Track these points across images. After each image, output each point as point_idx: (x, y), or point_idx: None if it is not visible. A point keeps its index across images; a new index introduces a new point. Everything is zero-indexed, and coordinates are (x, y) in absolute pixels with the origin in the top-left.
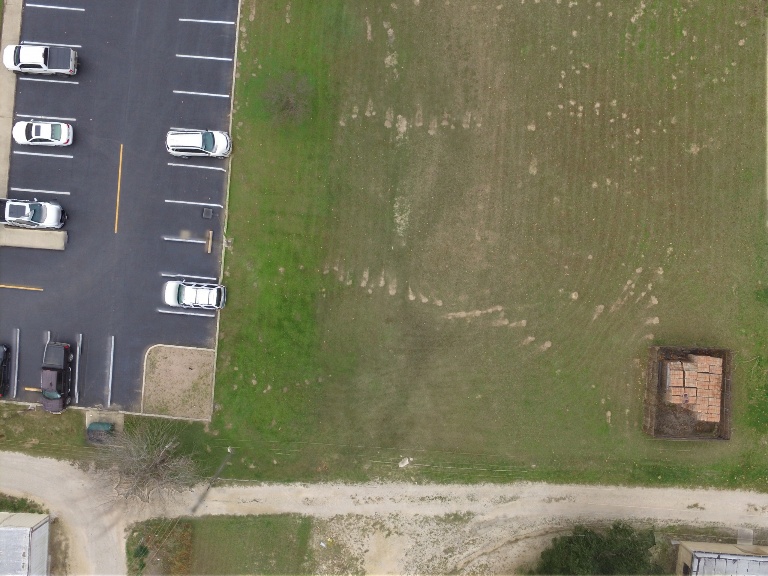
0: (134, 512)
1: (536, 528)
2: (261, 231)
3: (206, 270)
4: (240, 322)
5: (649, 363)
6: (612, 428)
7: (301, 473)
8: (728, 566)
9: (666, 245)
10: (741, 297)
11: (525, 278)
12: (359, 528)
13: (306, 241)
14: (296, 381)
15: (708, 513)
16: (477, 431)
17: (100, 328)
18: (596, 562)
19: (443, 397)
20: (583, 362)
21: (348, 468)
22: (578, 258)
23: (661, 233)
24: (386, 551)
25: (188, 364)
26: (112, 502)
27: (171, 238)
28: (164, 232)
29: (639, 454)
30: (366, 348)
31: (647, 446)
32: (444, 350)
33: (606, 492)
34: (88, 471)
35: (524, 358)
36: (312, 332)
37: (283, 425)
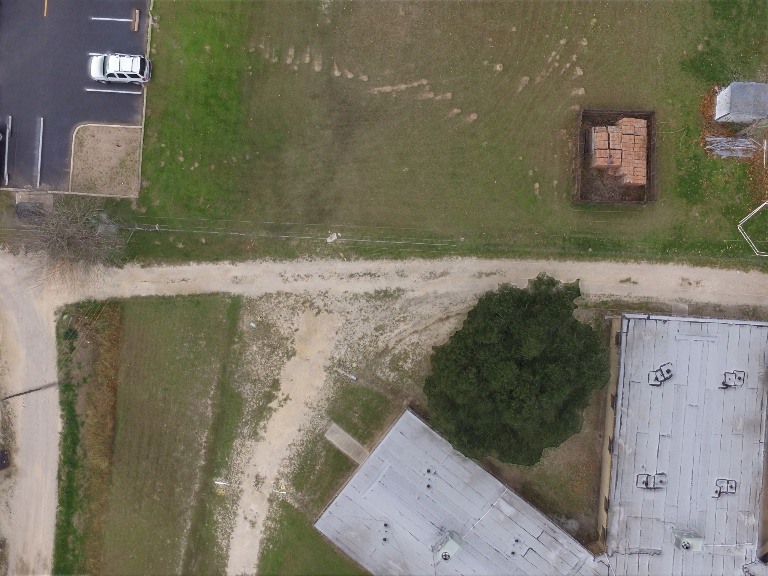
0: (64, 295)
1: (467, 304)
2: (187, 10)
3: (133, 48)
4: (167, 99)
5: (576, 134)
6: (540, 200)
7: (230, 251)
8: (658, 327)
9: (590, 16)
10: (667, 67)
11: (450, 52)
12: (289, 306)
13: (232, 20)
14: (223, 158)
15: (641, 287)
16: (405, 205)
17: (29, 110)
18: (519, 310)
19: (370, 171)
20: (510, 134)
21: (277, 245)
22: (502, 30)
23: (584, 5)
24: (316, 330)
25: (115, 141)
26: (42, 285)
27: (98, 17)
28: (91, 12)
29: (569, 226)
30: (293, 124)
31: (576, 218)
32: (370, 125)
33: (537, 266)
34: (18, 255)
35: (450, 130)
36: (239, 110)
37: (211, 203)
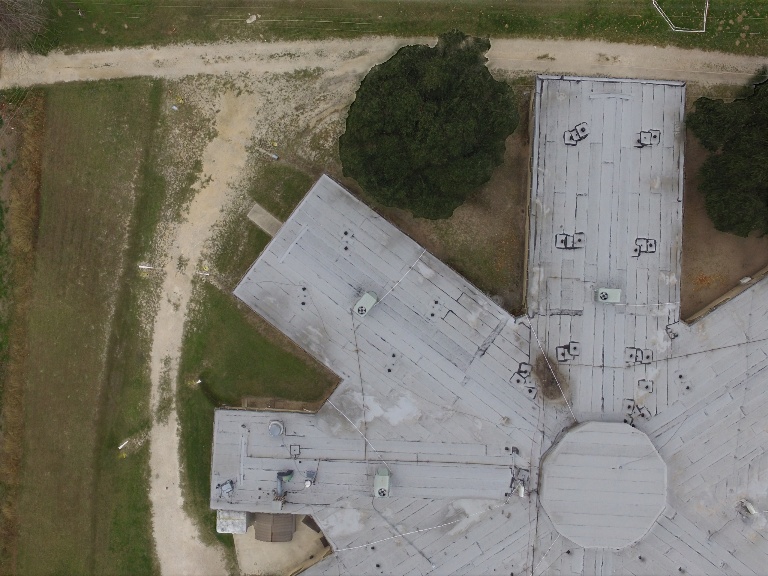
0: None
1: None
2: None
3: None
4: None
5: None
6: None
7: (151, 36)
8: (572, 87)
9: None
10: None
11: None
12: (210, 88)
13: None
14: None
15: (559, 63)
16: None
17: None
18: None
19: None
20: None
21: (197, 28)
22: None
23: None
24: (238, 110)
25: None
26: None
27: None
28: None
29: (485, 3)
30: None
31: None
32: None
33: None
34: None
35: None
36: None
37: None
